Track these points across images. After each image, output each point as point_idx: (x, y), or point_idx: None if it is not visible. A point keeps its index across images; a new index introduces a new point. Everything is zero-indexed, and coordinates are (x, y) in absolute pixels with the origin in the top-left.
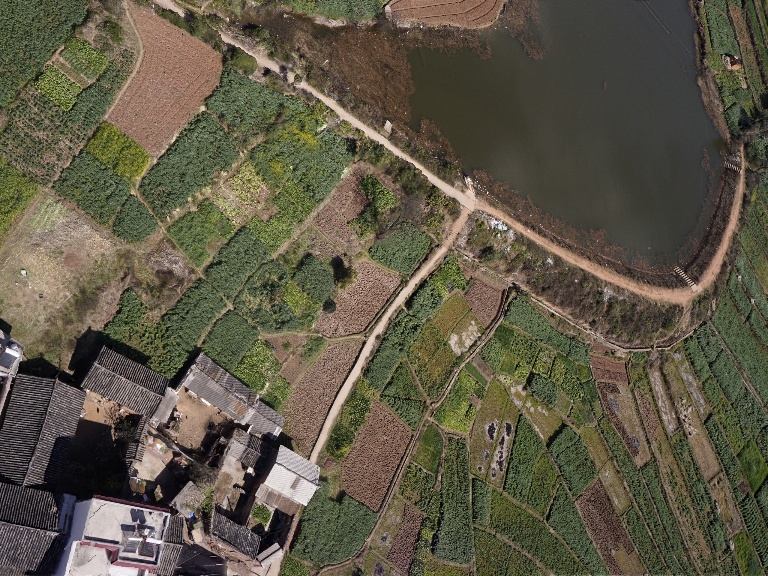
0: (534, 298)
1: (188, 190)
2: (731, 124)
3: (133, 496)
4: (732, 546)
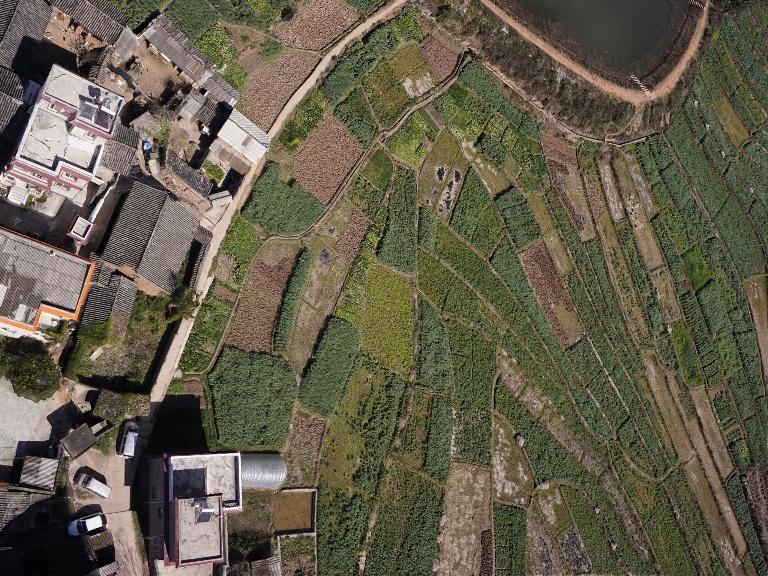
0: (489, 67)
1: None
2: None
3: None
4: (669, 329)
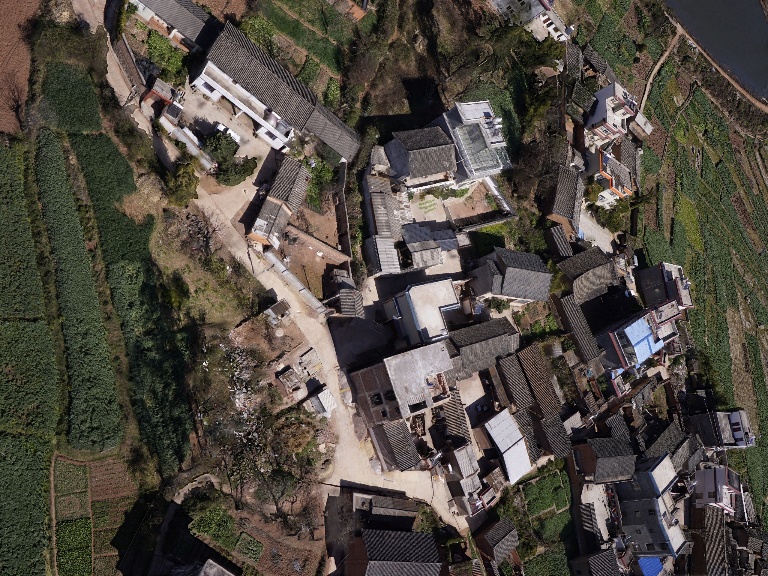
0: (704, 91)
1: None
2: None
3: None
4: None
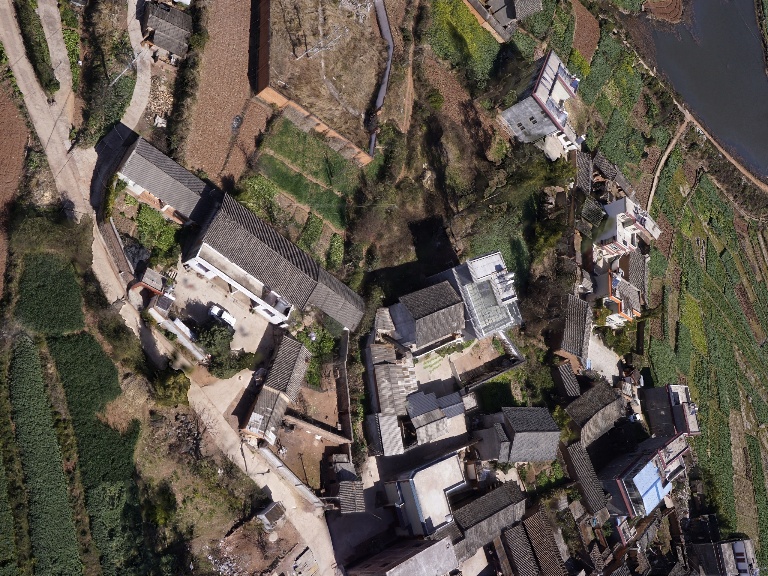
0: (710, 177)
1: (600, 85)
2: None
3: None
4: None
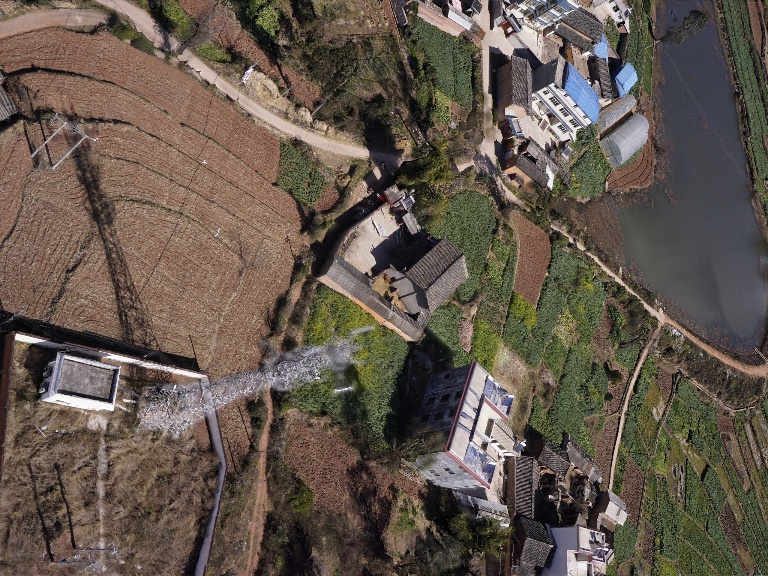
0: None
1: (550, 330)
2: None
3: (559, 523)
4: None
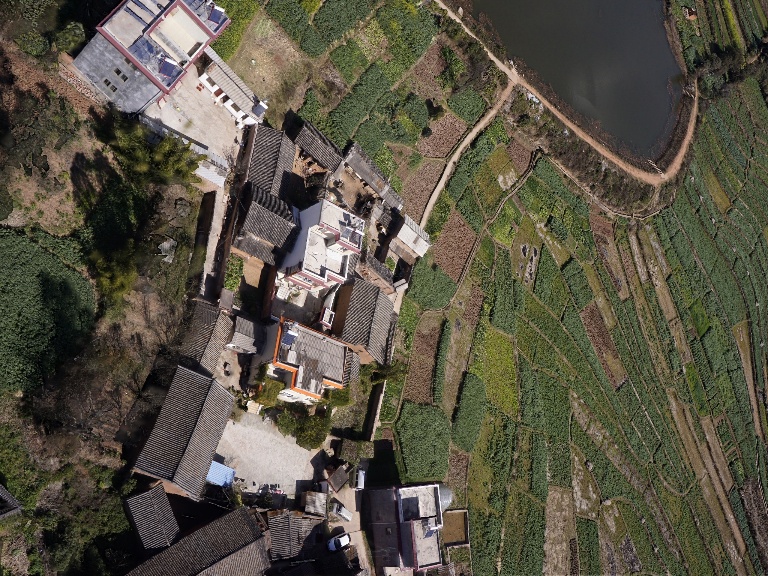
0: (553, 161)
1: (342, 28)
2: (688, 61)
3: None
4: (684, 370)
